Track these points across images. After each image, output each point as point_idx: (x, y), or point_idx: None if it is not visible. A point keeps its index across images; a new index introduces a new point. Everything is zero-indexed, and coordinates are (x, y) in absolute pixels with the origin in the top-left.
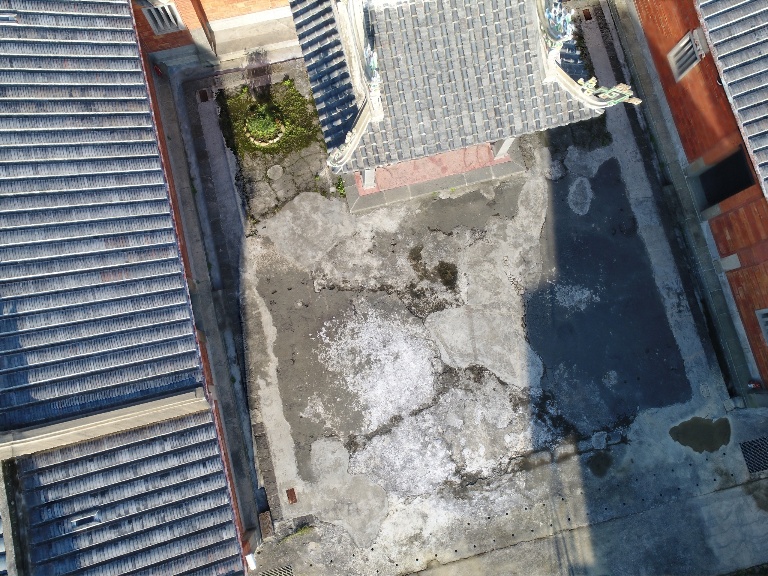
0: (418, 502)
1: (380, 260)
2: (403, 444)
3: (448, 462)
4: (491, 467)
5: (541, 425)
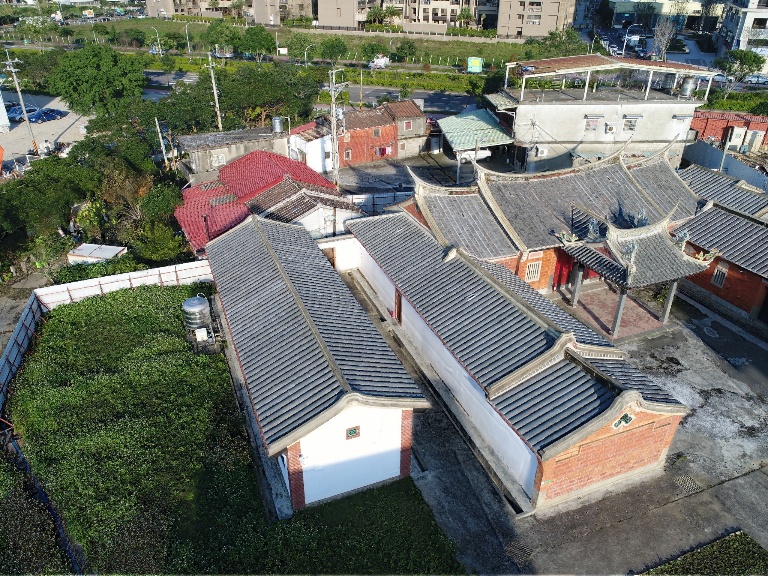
0: (732, 441)
1: (638, 359)
2: (705, 419)
3: (734, 423)
4: (757, 423)
5: (767, 405)
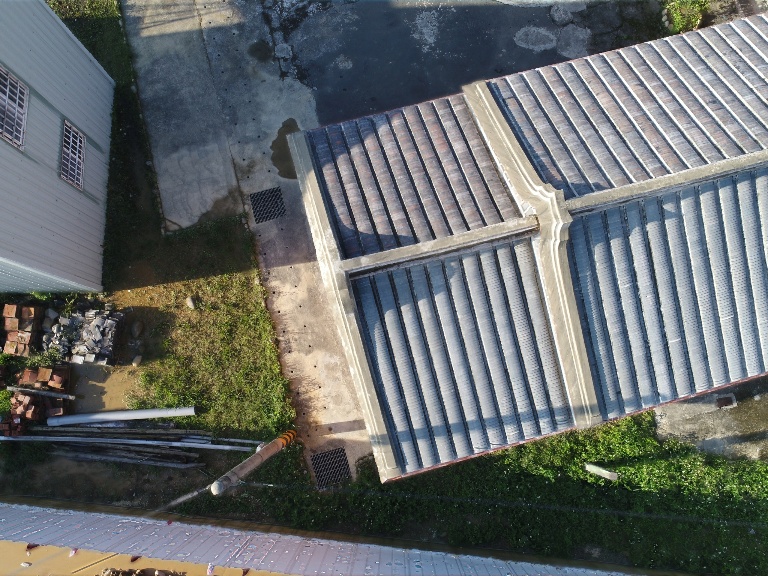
0: None
1: None
2: None
3: None
4: None
5: None
